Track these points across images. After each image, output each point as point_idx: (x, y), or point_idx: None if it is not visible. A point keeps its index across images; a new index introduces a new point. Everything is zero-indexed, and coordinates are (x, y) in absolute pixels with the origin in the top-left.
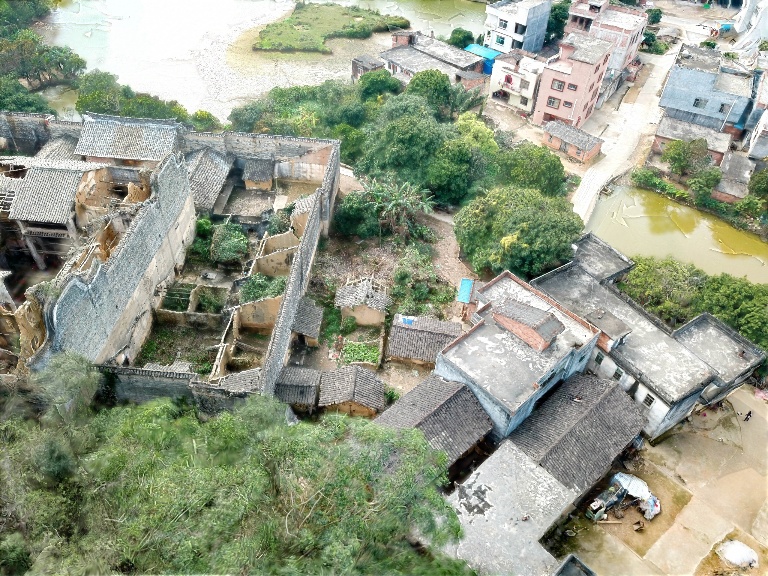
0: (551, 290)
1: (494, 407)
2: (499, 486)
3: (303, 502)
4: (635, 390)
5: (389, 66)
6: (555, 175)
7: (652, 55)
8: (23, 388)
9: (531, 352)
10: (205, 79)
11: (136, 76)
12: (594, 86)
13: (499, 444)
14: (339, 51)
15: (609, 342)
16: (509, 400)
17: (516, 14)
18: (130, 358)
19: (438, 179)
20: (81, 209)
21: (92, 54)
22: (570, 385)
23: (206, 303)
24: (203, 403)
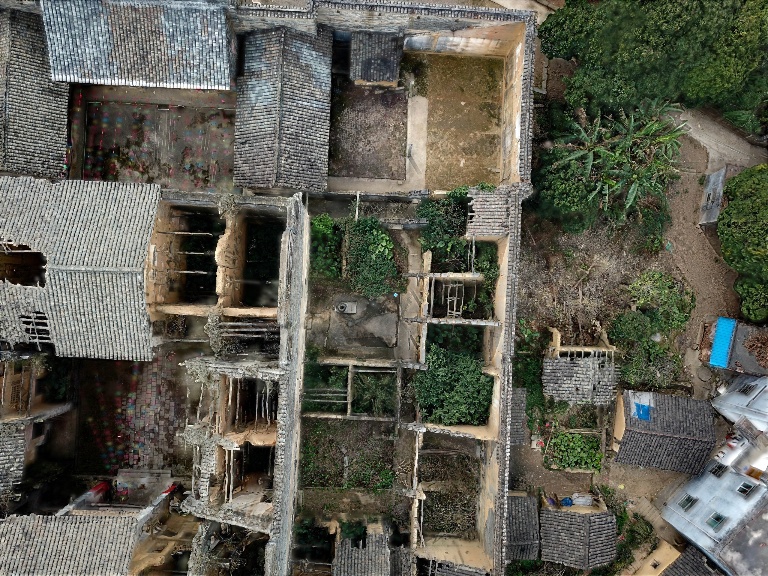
0: None
1: None
2: None
3: None
4: None
5: None
6: None
7: None
8: None
9: None
10: None
11: None
12: None
13: None
14: None
15: None
16: None
17: None
18: (295, 493)
19: (703, 90)
20: None
21: None
22: None
23: (367, 395)
24: None
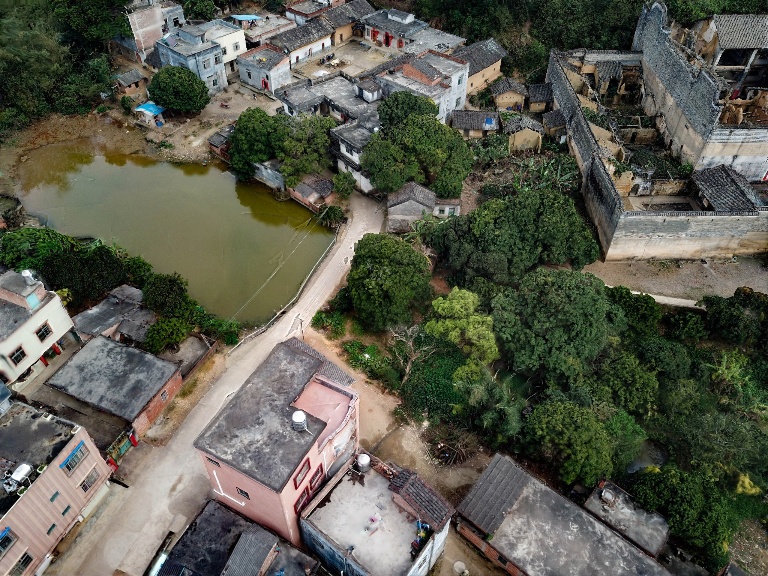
0: None
1: None
2: None
3: None
4: None
5: None
6: None
7: None
8: None
9: None
10: None
11: None
12: None
13: None
14: None
15: None
16: None
17: None
18: None
19: None
20: None
21: None
22: None
23: None
24: None
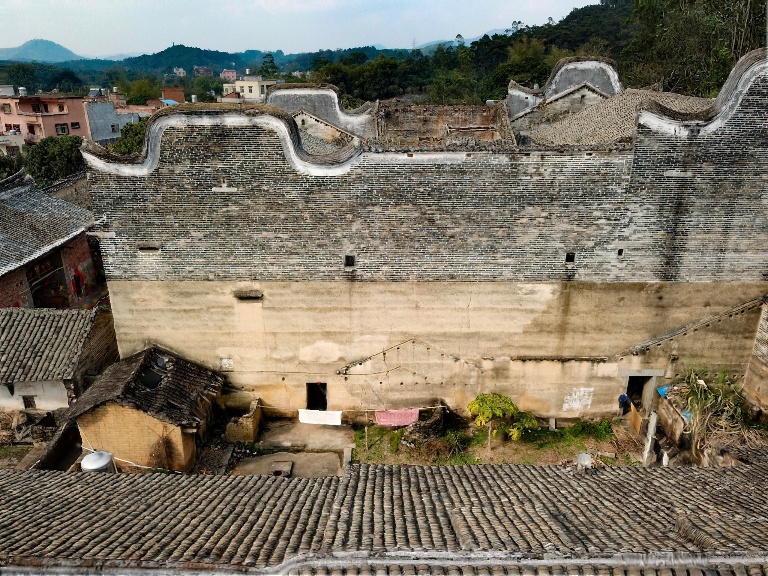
0: None
1: None
2: None
3: None
4: None
5: None
6: None
7: None
8: None
9: None
10: None
11: None
12: None
13: None
14: None
15: None
16: None
17: None
18: None
19: None
20: None
21: None
22: None
23: None
24: None
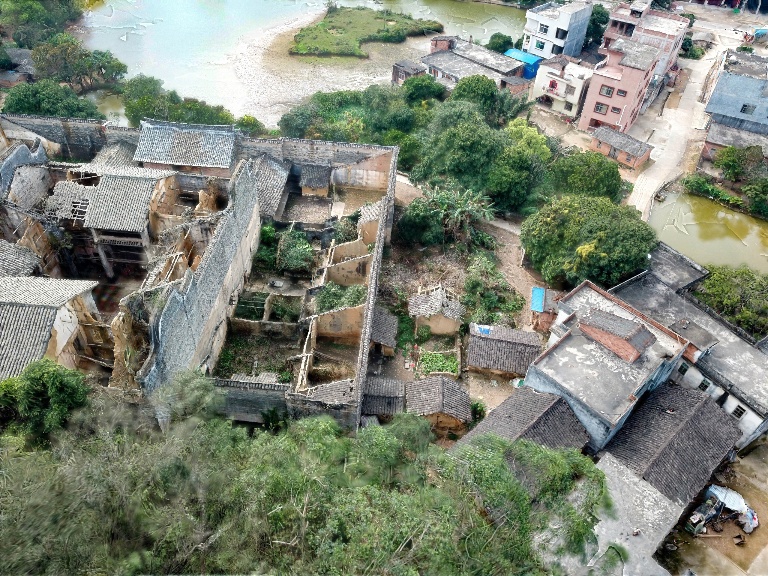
0: (628, 299)
1: (591, 419)
2: (605, 500)
3: (485, 525)
4: (723, 401)
5: (430, 71)
6: (613, 182)
7: (689, 60)
8: (148, 403)
9: (622, 363)
10: (245, 83)
11: (176, 80)
12: (642, 92)
13: (594, 456)
14: (375, 55)
15: (696, 353)
16: (607, 412)
17: (557, 19)
18: (210, 368)
19: (498, 186)
20: (154, 217)
21: (129, 58)
22: (659, 396)
23: (280, 312)
24: (296, 415)
